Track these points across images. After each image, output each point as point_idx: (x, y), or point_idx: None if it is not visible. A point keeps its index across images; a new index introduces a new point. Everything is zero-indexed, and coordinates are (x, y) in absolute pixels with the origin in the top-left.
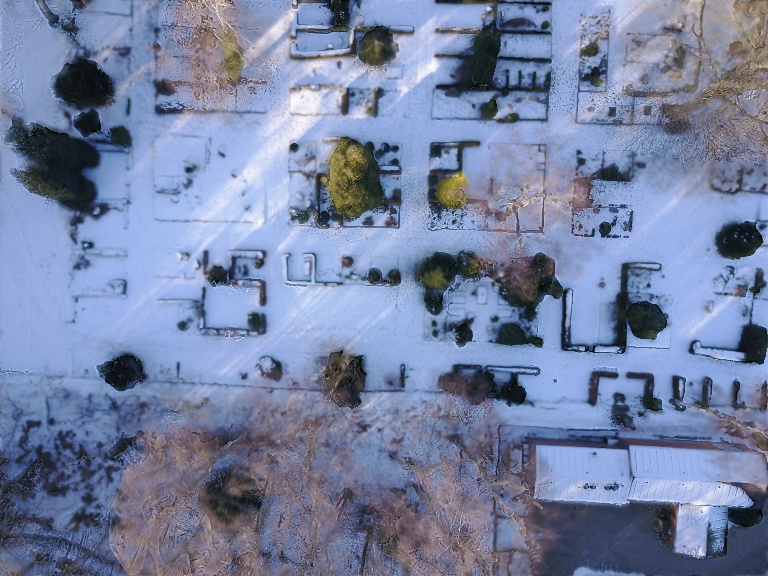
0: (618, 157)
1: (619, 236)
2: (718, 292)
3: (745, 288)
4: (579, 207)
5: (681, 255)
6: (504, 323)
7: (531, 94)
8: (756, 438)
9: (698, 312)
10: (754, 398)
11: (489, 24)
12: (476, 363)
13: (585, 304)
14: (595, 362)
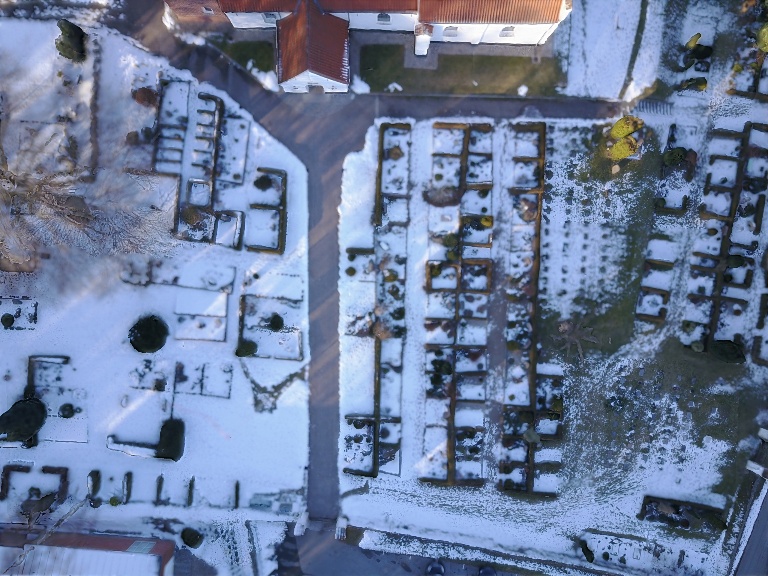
0: None
1: (23, 328)
2: (134, 386)
3: (163, 382)
4: None
5: (94, 348)
6: None
7: None
8: (182, 535)
9: (115, 406)
10: (181, 494)
11: None
12: None
13: None
14: (10, 455)
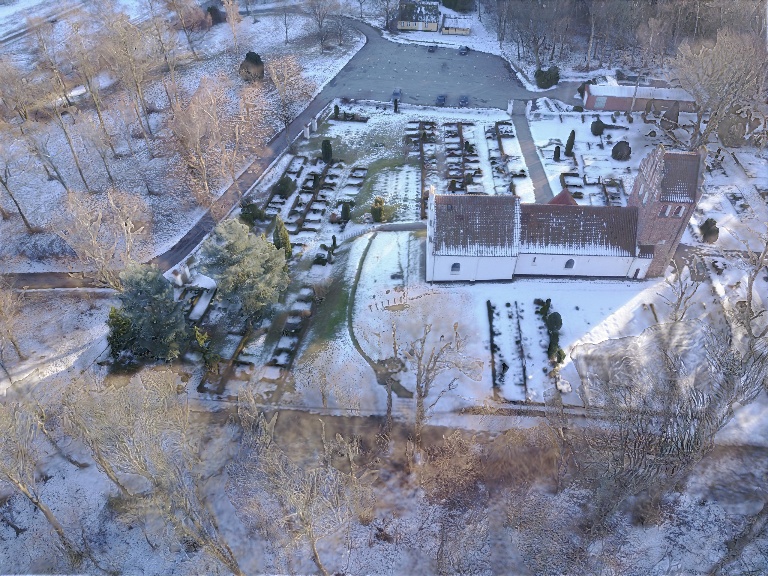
0: None
1: None
2: None
3: (609, 143)
4: None
5: None
6: None
7: None
8: None
9: None
10: (588, 119)
11: None
12: None
13: None
14: None
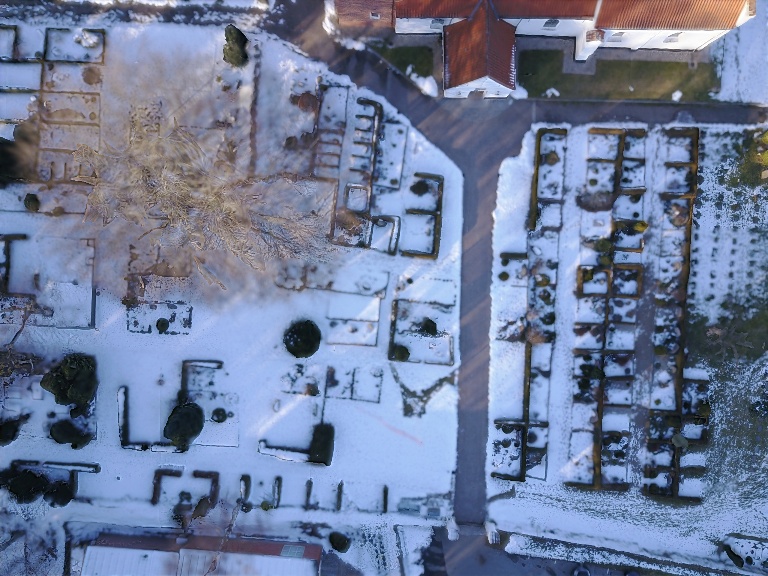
0: (174, 252)
1: (178, 333)
2: (286, 391)
3: (314, 387)
4: (133, 303)
5: (247, 352)
6: (60, 419)
7: (78, 187)
8: (330, 539)
9: (266, 410)
10: (329, 498)
11: (32, 115)
12: (36, 459)
13: (145, 401)
14: (161, 460)
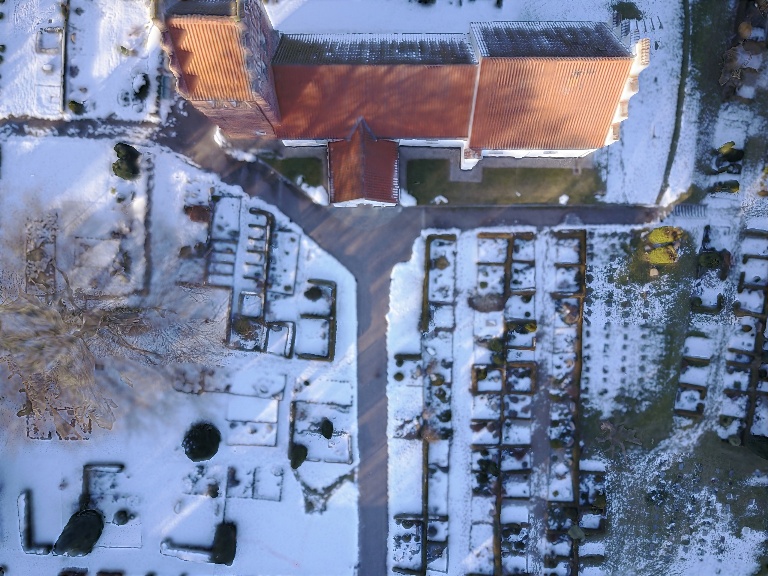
0: None
1: None
2: (187, 492)
3: (215, 488)
4: None
5: (147, 455)
6: None
7: None
8: None
9: (168, 512)
10: None
11: None
12: None
13: (46, 506)
14: (64, 562)
